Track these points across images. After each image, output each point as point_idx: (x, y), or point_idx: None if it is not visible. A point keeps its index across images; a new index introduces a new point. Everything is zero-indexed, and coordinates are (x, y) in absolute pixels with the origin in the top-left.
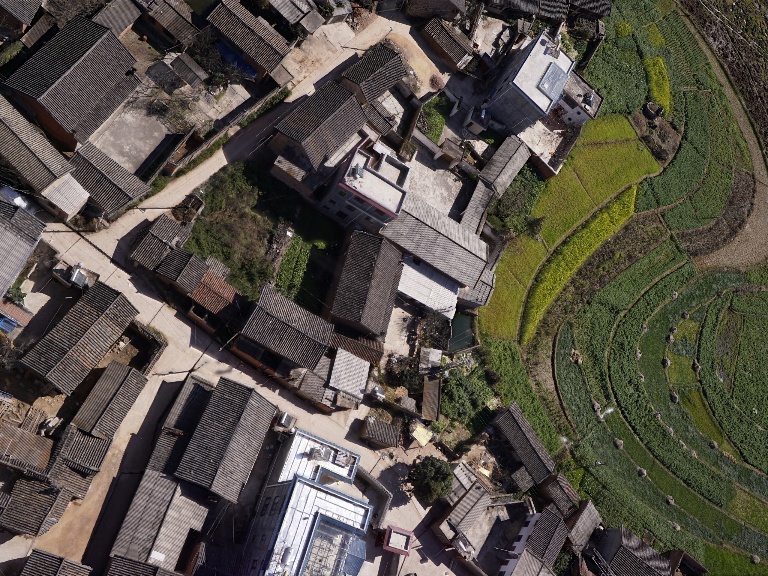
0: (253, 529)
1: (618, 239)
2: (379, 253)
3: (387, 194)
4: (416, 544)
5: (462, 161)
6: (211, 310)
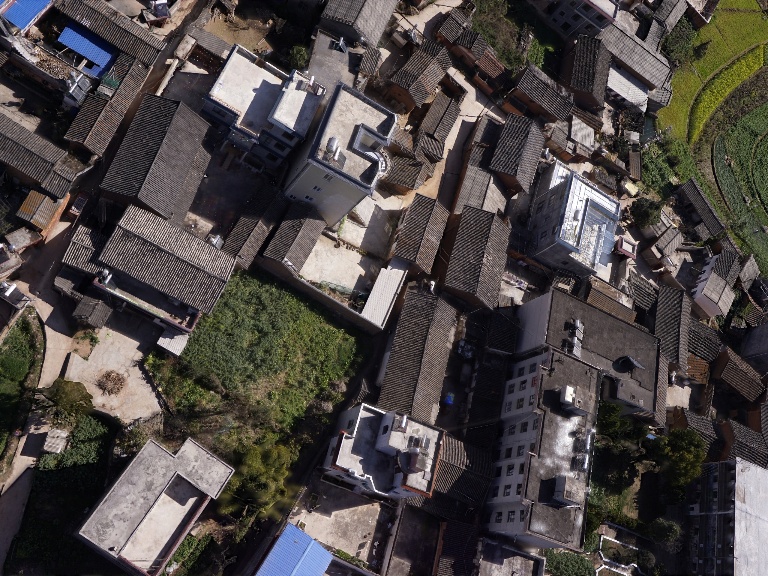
0: (532, 223)
1: (752, 83)
2: (599, 49)
3: (606, 5)
4: (632, 263)
5: (641, 4)
6: (491, 75)
